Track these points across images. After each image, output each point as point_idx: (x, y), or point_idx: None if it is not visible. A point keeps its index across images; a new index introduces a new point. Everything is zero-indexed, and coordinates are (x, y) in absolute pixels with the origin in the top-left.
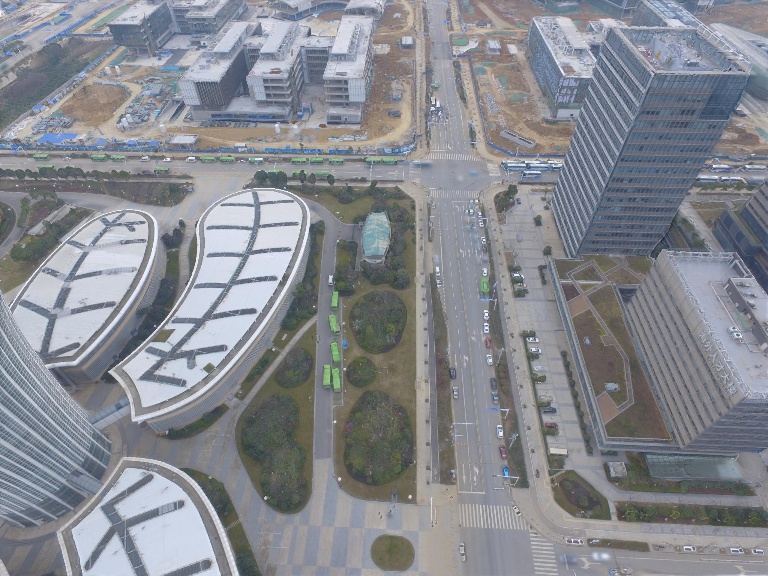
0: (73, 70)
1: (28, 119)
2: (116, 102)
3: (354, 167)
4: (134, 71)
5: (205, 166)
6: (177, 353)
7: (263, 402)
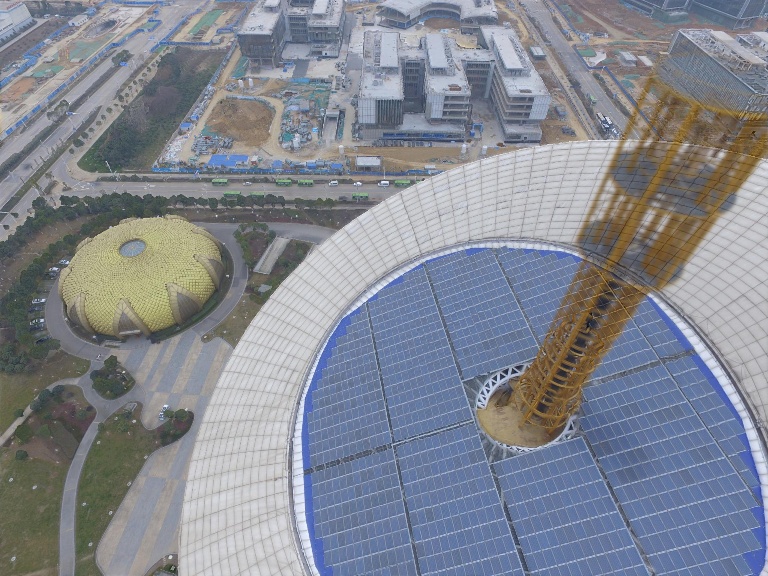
0: (200, 83)
1: (180, 138)
2: (265, 119)
3: None
4: (264, 84)
5: None
6: None
7: None
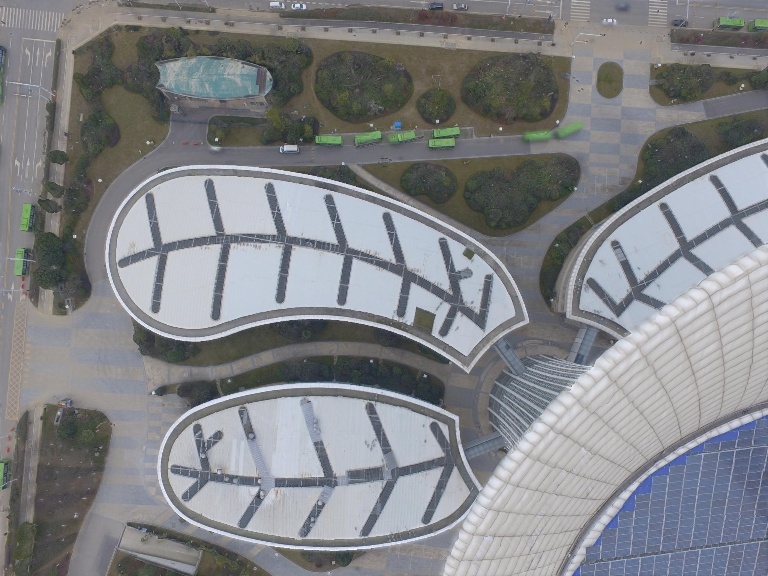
0: None
1: None
2: None
3: (8, 126)
4: None
5: None
6: (453, 294)
7: (481, 205)
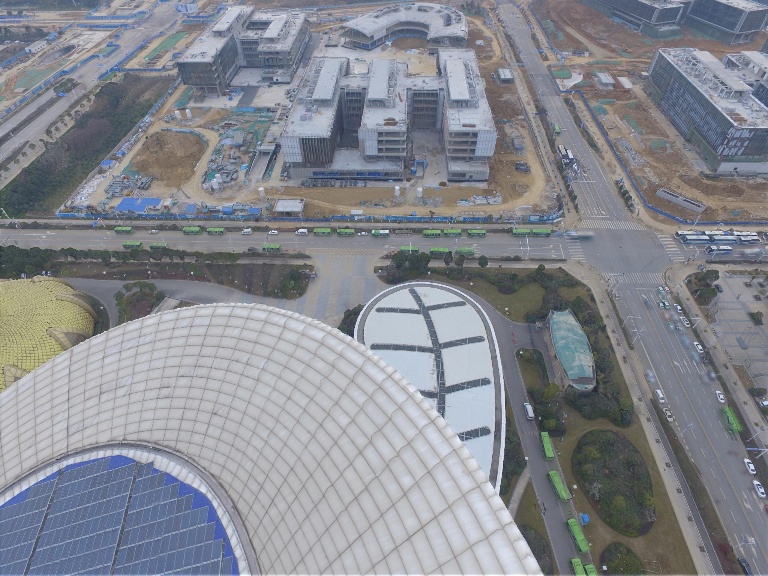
0: (137, 114)
1: (97, 178)
2: (194, 154)
3: (499, 240)
4: (205, 114)
5: (320, 240)
6: None
7: None
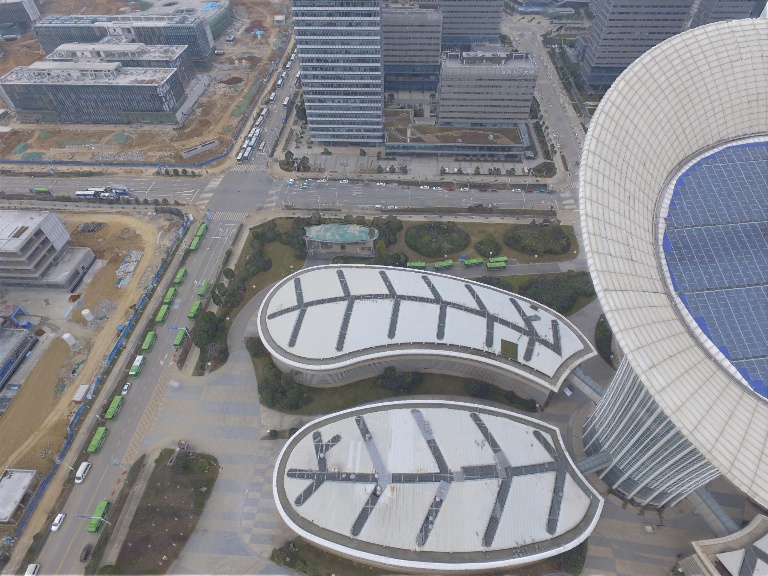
0: None
1: None
2: None
3: (197, 263)
4: None
5: (112, 445)
6: (529, 329)
7: None
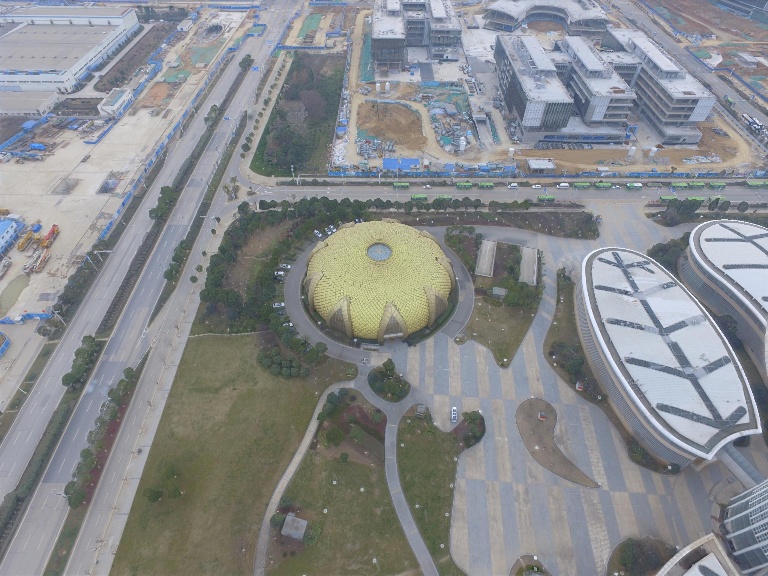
0: (336, 87)
1: (340, 142)
2: (415, 122)
3: (737, 191)
4: (397, 87)
5: (582, 193)
6: None
7: None
